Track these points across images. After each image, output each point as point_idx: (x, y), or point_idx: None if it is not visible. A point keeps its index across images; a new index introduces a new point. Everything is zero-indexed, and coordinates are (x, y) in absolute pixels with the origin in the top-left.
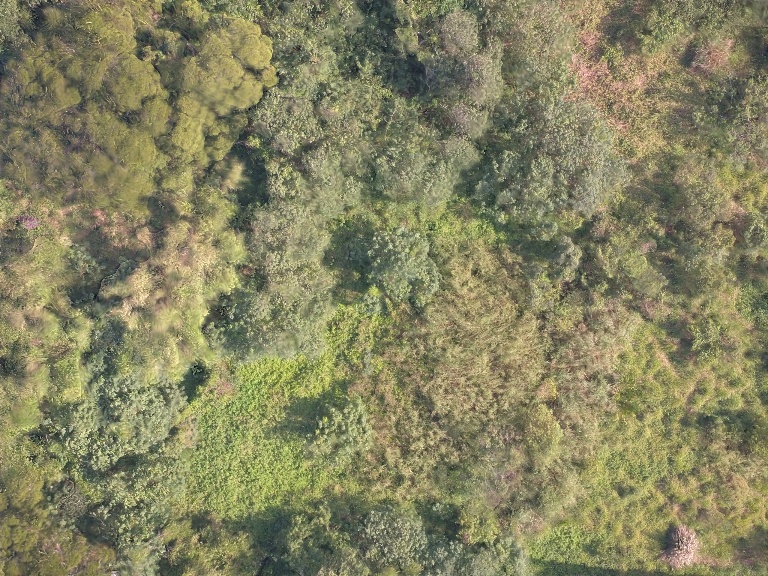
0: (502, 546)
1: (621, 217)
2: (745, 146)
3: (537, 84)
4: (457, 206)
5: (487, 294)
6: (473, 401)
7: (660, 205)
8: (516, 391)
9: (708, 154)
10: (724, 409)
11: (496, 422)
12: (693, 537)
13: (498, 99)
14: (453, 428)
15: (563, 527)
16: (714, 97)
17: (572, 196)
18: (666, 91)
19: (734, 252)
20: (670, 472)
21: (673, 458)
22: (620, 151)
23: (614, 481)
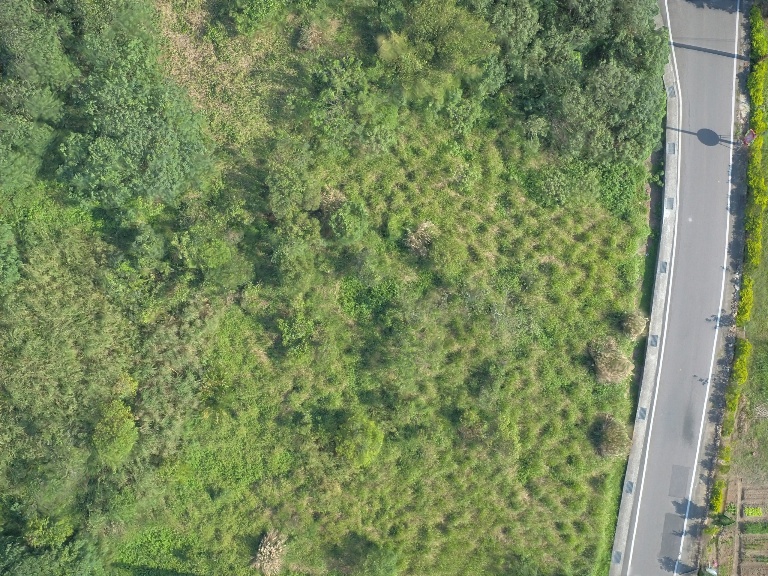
0: (69, 549)
1: (217, 205)
2: (332, 131)
3: (109, 63)
4: (54, 192)
5: (71, 284)
6: (51, 396)
7: (261, 193)
8: (97, 386)
9: (313, 140)
10: (322, 408)
11: (76, 418)
12: (282, 543)
13: (70, 79)
14: (31, 424)
15: (153, 530)
16: (321, 80)
17: (144, 181)
18: (268, 73)
19: (337, 243)
20: (266, 474)
21: (267, 459)
22: (224, 136)
23: (206, 483)
